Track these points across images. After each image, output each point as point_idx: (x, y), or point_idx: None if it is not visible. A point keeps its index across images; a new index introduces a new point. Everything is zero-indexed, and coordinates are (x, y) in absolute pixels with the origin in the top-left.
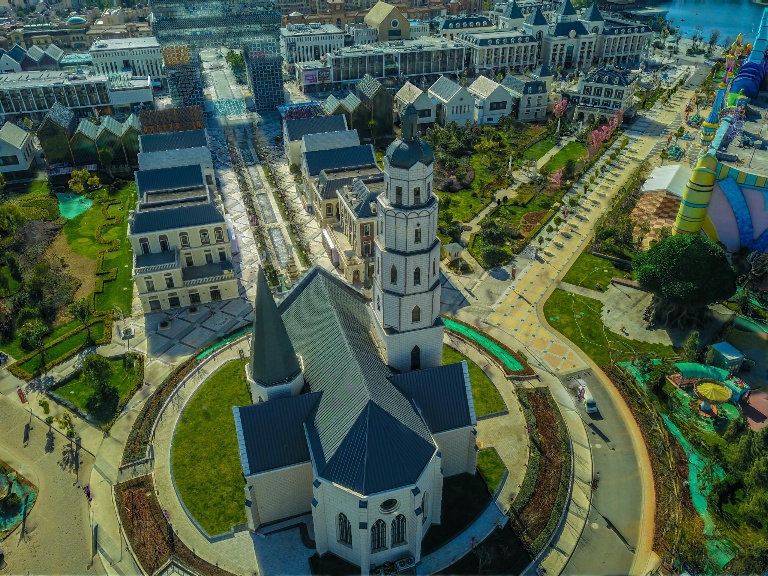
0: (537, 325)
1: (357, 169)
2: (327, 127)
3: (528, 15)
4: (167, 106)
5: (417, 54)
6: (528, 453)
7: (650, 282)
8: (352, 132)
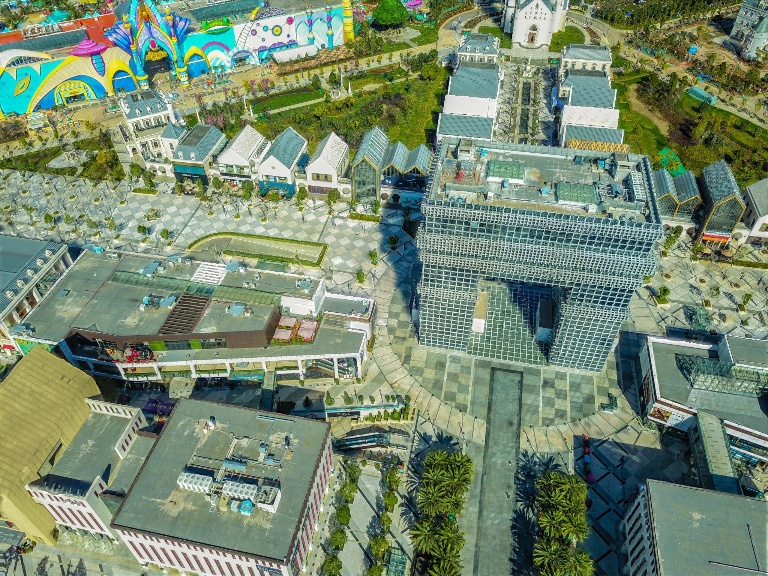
0: None
1: None
2: None
3: None
4: None
5: None
6: (485, 20)
7: None
8: None
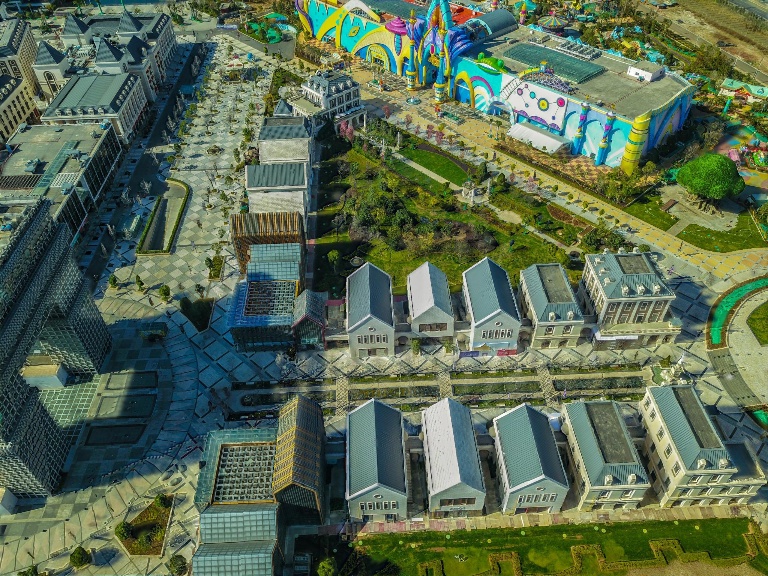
0: (726, 258)
1: (542, 280)
2: (380, 286)
3: (20, 48)
4: (3, 501)
5: (92, 163)
6: None
7: (728, 193)
8: (430, 266)
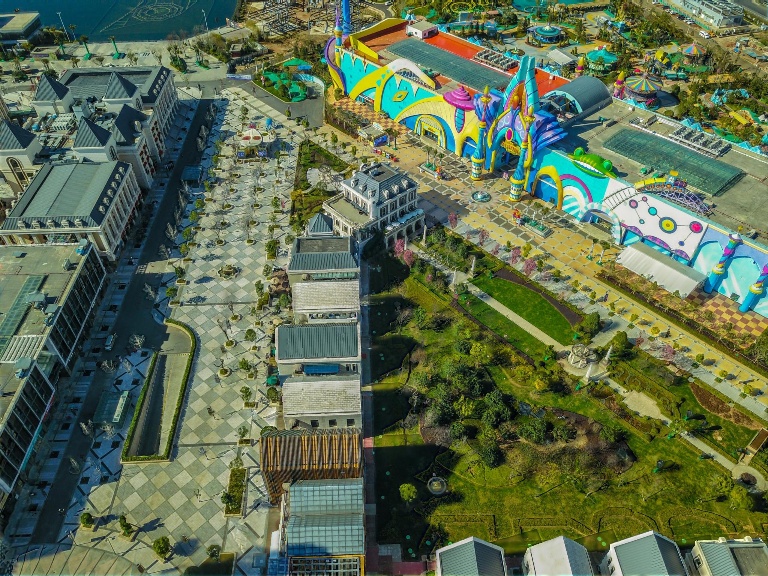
0: None
1: None
2: None
3: None
4: None
5: (63, 312)
6: None
7: None
8: (567, 546)
